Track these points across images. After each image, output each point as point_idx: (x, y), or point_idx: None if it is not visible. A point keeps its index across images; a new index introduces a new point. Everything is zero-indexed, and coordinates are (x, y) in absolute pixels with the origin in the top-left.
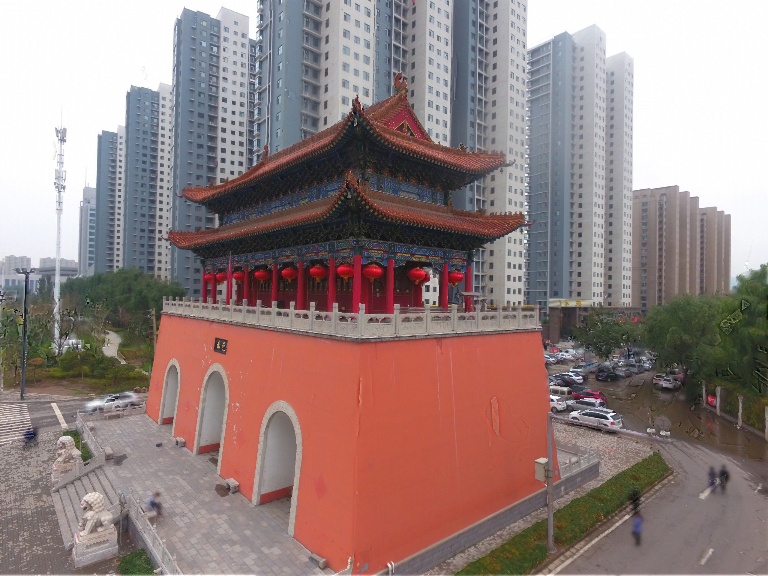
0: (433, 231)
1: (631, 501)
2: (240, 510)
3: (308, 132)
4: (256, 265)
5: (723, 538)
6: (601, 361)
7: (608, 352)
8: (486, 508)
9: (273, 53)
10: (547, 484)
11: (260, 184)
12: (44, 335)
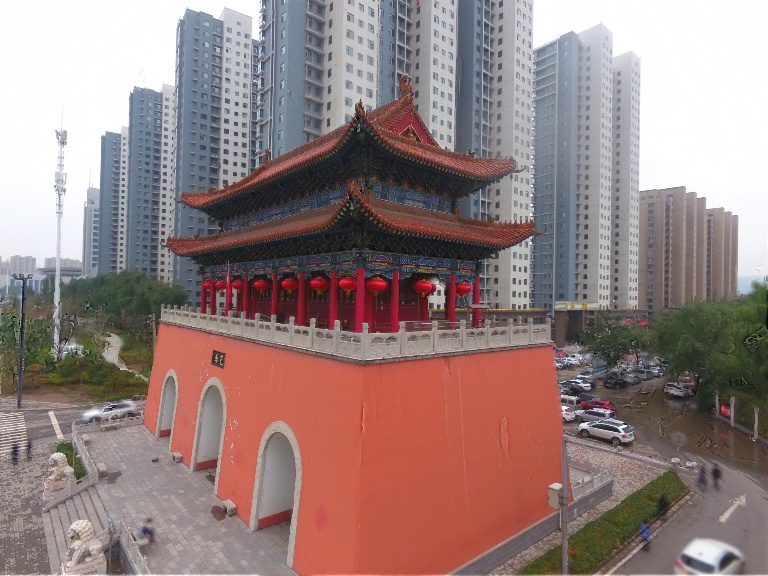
0: (440, 241)
1: (648, 525)
2: (237, 536)
3: (311, 134)
4: (256, 274)
5: (748, 568)
6: (609, 367)
7: (616, 358)
8: (496, 536)
9: (276, 54)
10: (561, 512)
11: (260, 190)
12: (43, 340)
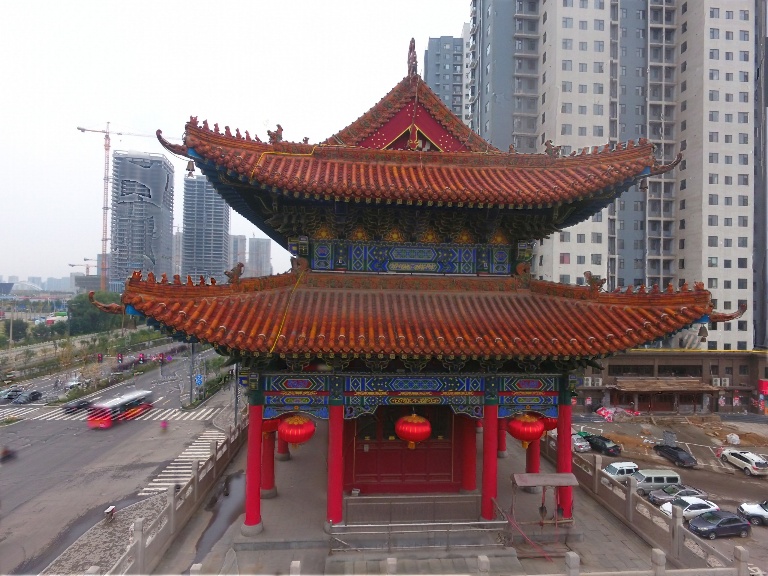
0: None
1: None
2: None
3: (523, 137)
4: None
5: None
6: None
7: None
8: None
9: (482, 56)
10: None
11: None
12: None
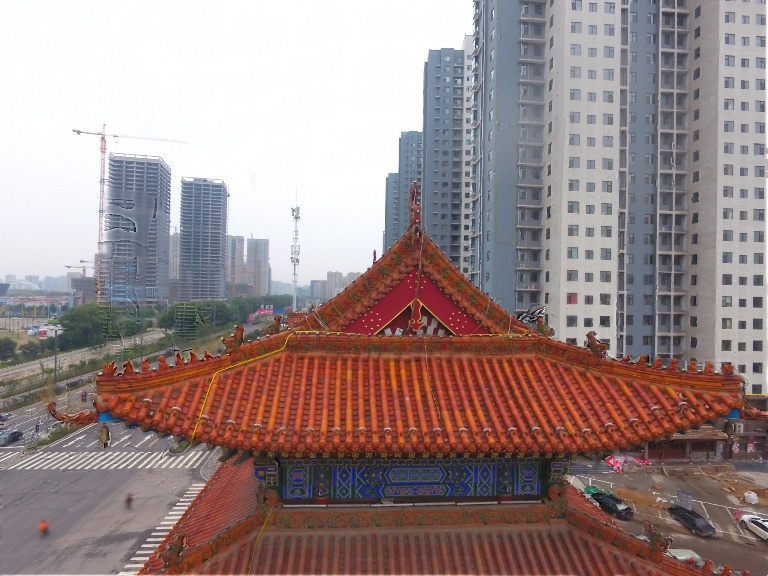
0: None
1: None
2: None
3: (528, 167)
4: None
5: None
6: None
7: None
8: None
9: (485, 80)
10: None
11: None
12: None
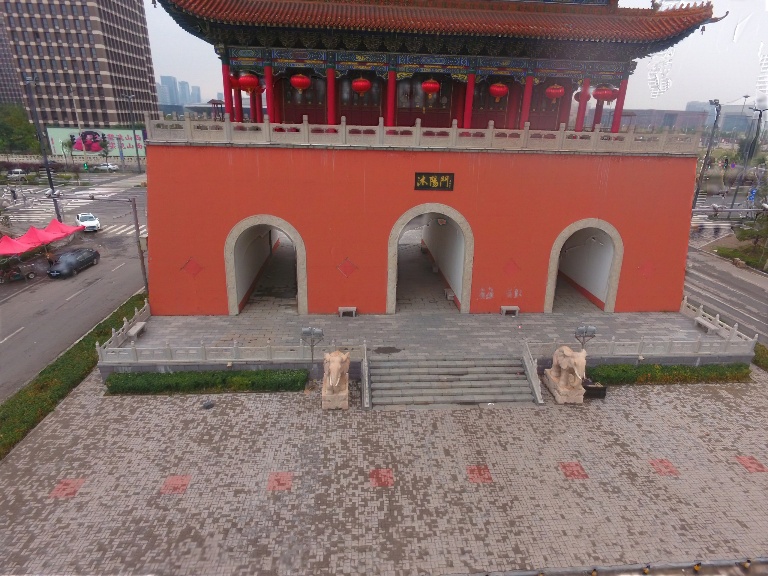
0: None
1: None
2: None
3: None
4: None
5: None
6: None
7: None
8: None
9: None
10: None
11: None
12: None
